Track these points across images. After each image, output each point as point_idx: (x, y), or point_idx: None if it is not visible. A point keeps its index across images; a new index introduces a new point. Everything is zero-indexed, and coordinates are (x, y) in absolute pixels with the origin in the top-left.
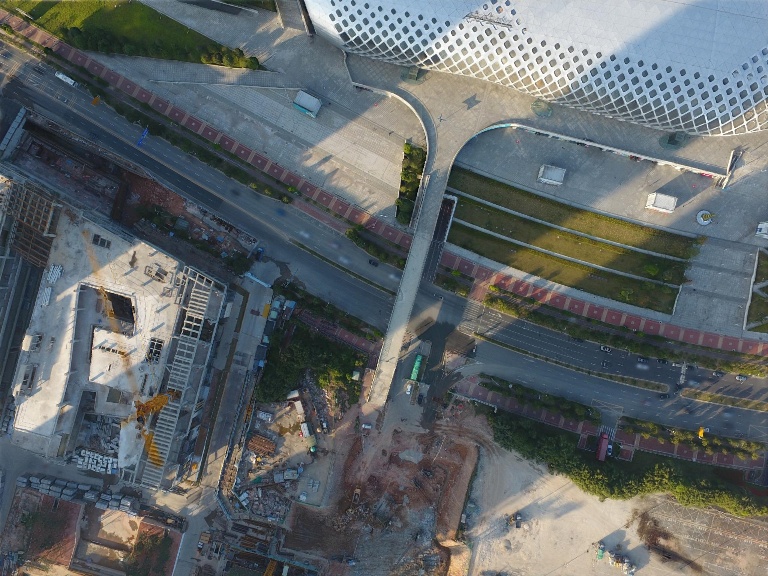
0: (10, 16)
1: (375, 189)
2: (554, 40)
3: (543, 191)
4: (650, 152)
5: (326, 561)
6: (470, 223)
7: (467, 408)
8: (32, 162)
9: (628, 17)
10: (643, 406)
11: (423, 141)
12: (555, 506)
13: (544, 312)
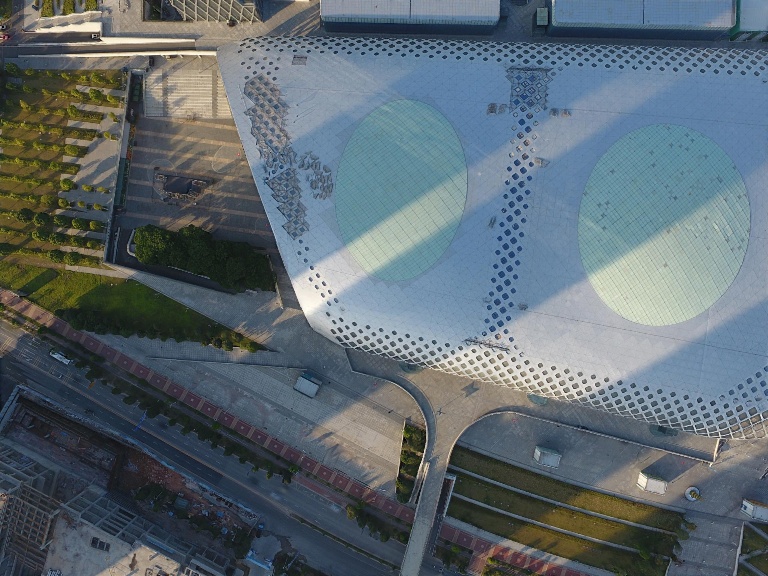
0: (2, 291)
1: (375, 464)
2: (550, 363)
3: (539, 468)
4: (641, 438)
5: None
6: (468, 498)
7: None
8: (25, 434)
9: (621, 348)
10: None
11: (422, 420)
12: None
13: None
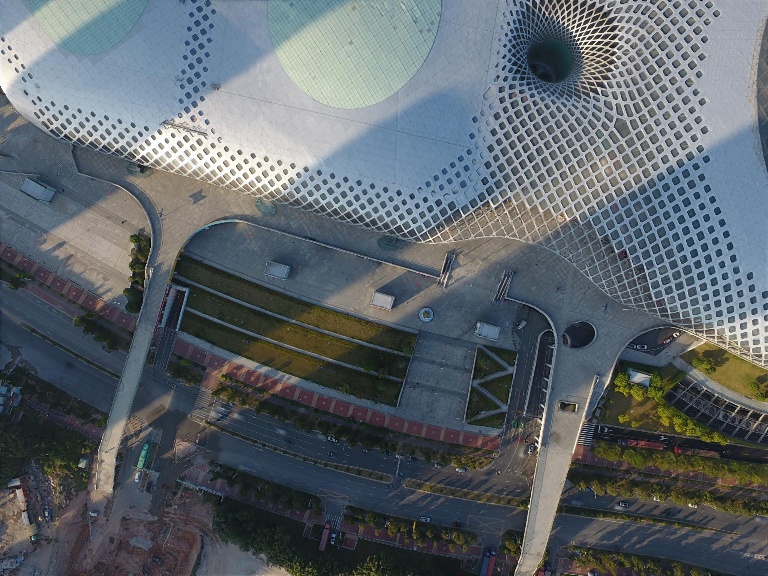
0: None
1: (109, 276)
2: (249, 150)
3: (273, 284)
4: (369, 252)
5: None
6: (202, 313)
7: (195, 496)
8: None
9: (315, 133)
10: (368, 496)
11: None
12: None
13: (274, 402)
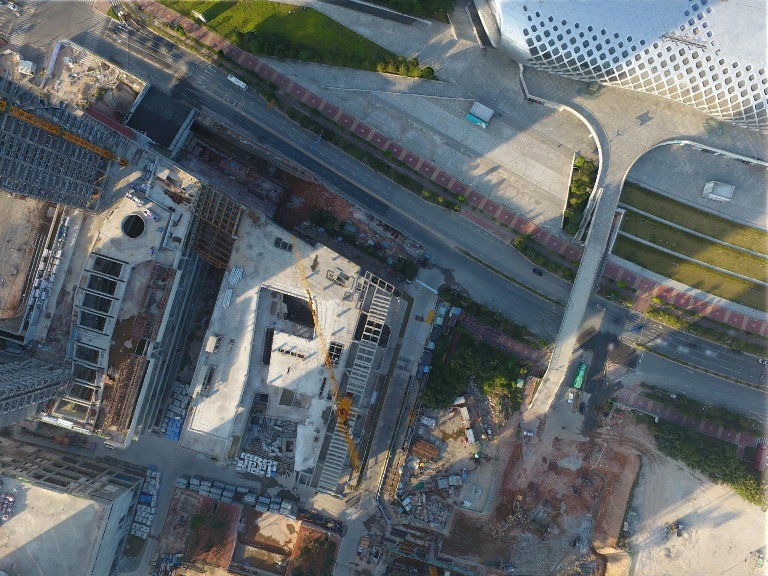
0: (181, 18)
1: (541, 200)
2: (746, 62)
3: (707, 206)
4: None
5: (483, 567)
6: (634, 236)
7: (628, 417)
8: (196, 163)
9: None
10: None
11: (591, 154)
12: (714, 515)
13: (704, 324)
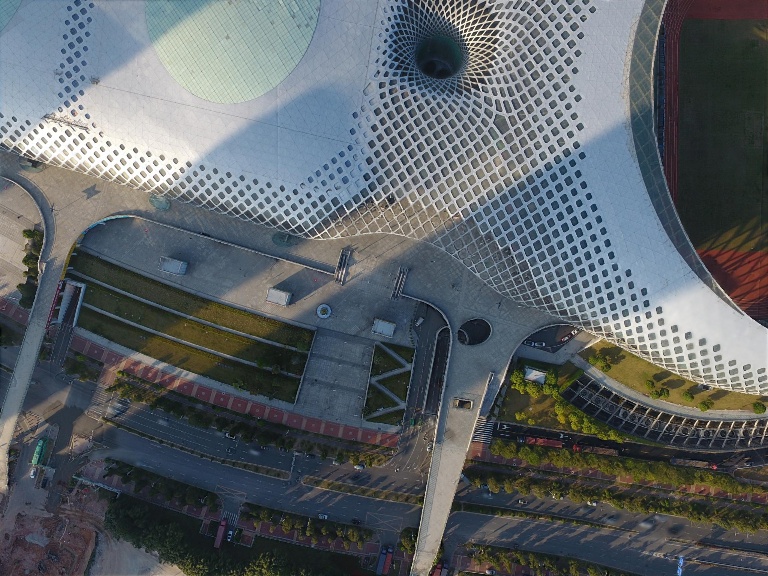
0: None
1: (6, 271)
2: (131, 144)
3: (170, 280)
4: (264, 248)
5: None
6: (99, 308)
7: (91, 493)
8: None
9: (196, 127)
10: (265, 493)
11: None
12: None
13: (172, 398)
